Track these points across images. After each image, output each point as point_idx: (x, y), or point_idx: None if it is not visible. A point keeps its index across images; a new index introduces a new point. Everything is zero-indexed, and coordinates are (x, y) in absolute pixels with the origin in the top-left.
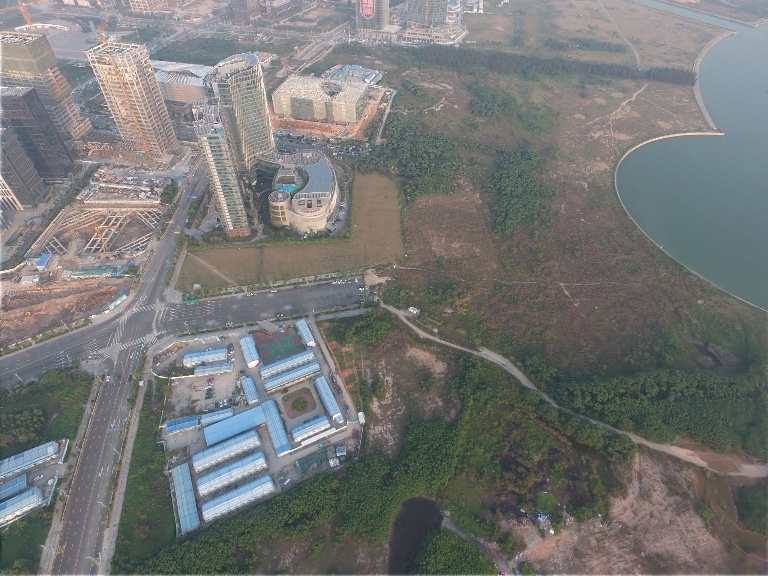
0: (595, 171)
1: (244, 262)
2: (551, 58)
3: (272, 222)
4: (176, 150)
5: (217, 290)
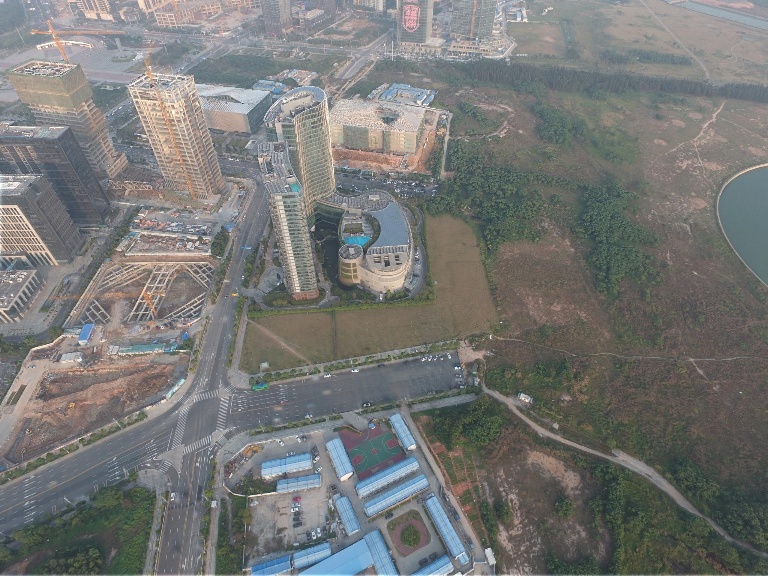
0: (694, 210)
1: (315, 332)
2: (612, 73)
3: (341, 279)
4: (221, 188)
5: (290, 372)
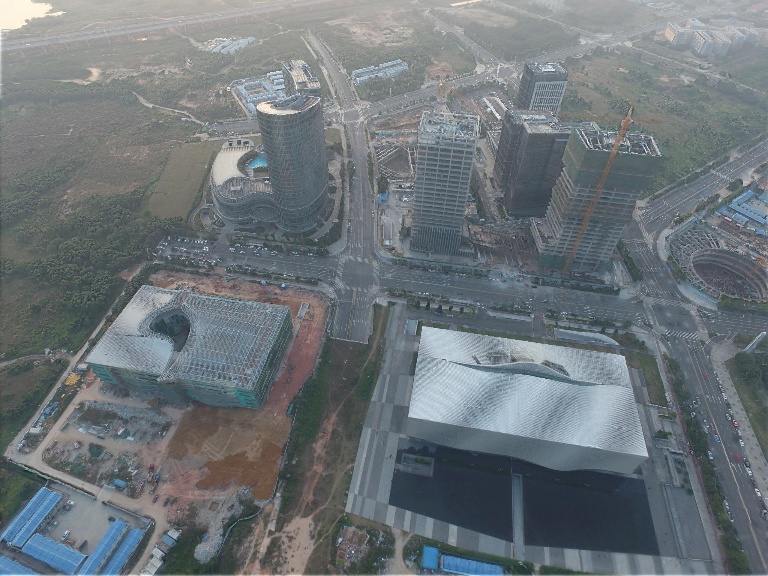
0: None
1: None
2: None
3: None
4: None
5: None
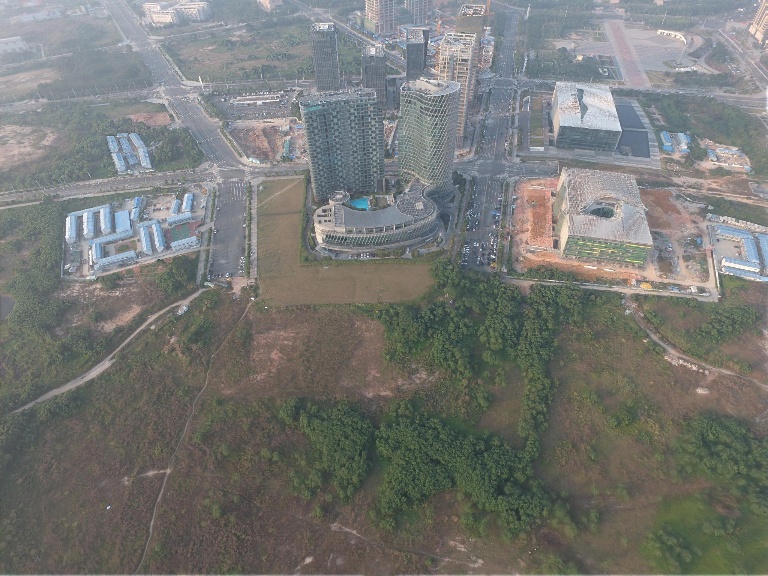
0: None
1: (284, 205)
2: None
3: None
4: None
5: (249, 195)
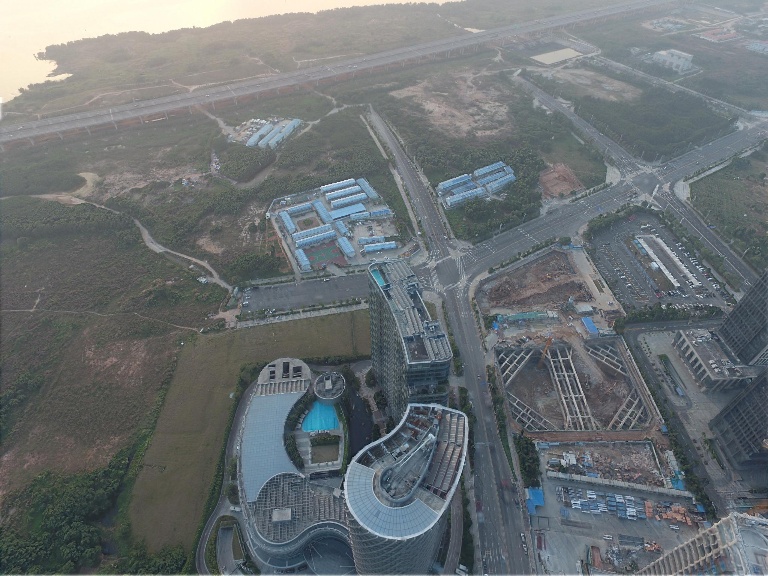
0: None
1: None
2: None
3: None
4: None
5: None
